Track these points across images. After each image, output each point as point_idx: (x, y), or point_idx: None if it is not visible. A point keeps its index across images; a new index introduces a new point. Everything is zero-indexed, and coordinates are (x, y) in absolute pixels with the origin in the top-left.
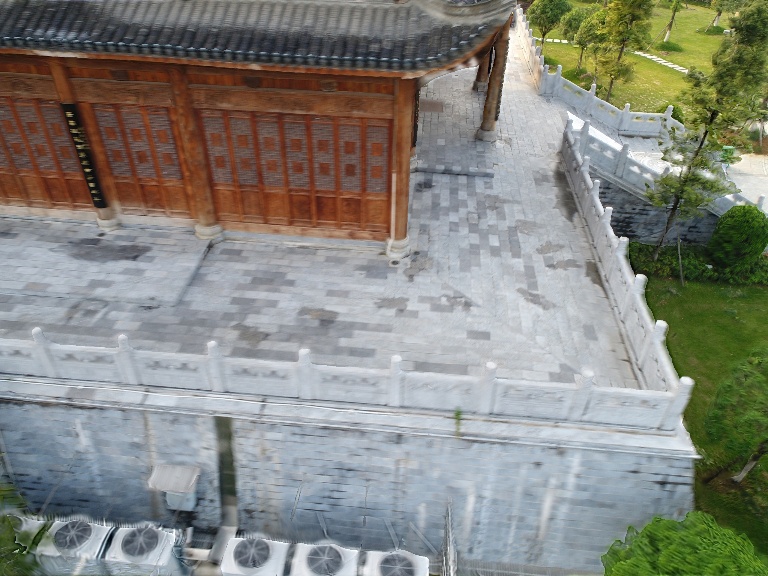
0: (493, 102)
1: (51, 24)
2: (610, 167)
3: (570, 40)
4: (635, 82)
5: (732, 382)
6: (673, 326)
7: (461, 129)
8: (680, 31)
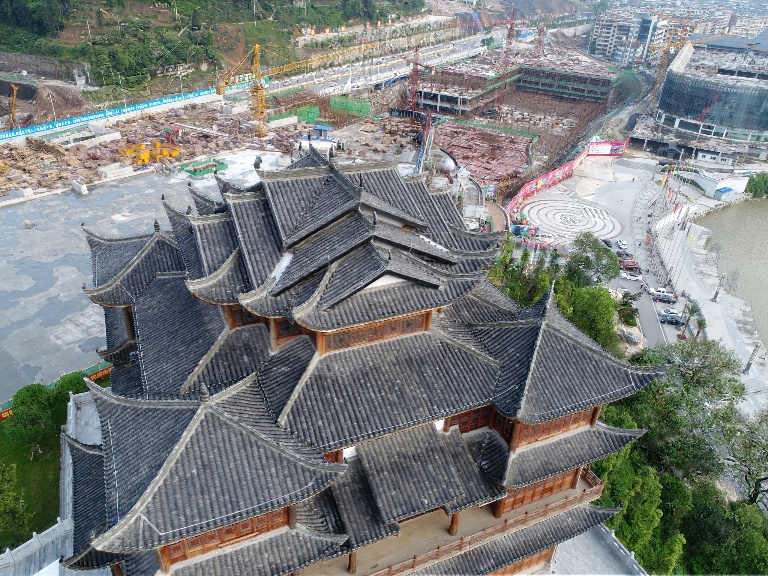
0: None
1: None
2: None
3: None
4: None
5: (46, 429)
6: (34, 510)
7: None
8: None
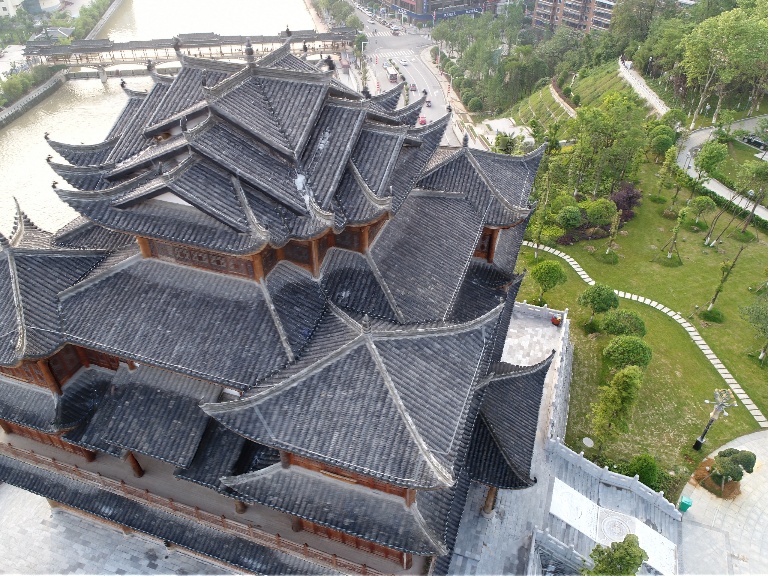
0: (490, 503)
1: (251, 555)
2: (562, 553)
3: (608, 334)
4: (660, 371)
5: None
6: None
7: (474, 499)
8: (734, 286)
